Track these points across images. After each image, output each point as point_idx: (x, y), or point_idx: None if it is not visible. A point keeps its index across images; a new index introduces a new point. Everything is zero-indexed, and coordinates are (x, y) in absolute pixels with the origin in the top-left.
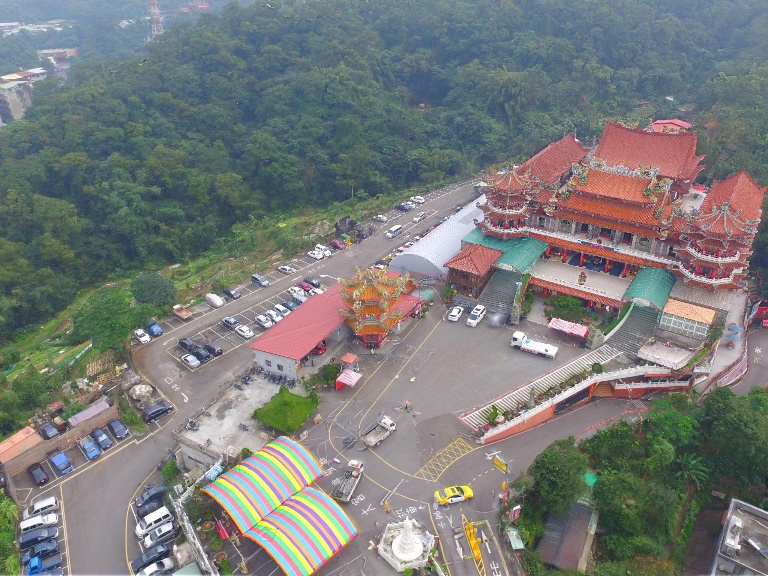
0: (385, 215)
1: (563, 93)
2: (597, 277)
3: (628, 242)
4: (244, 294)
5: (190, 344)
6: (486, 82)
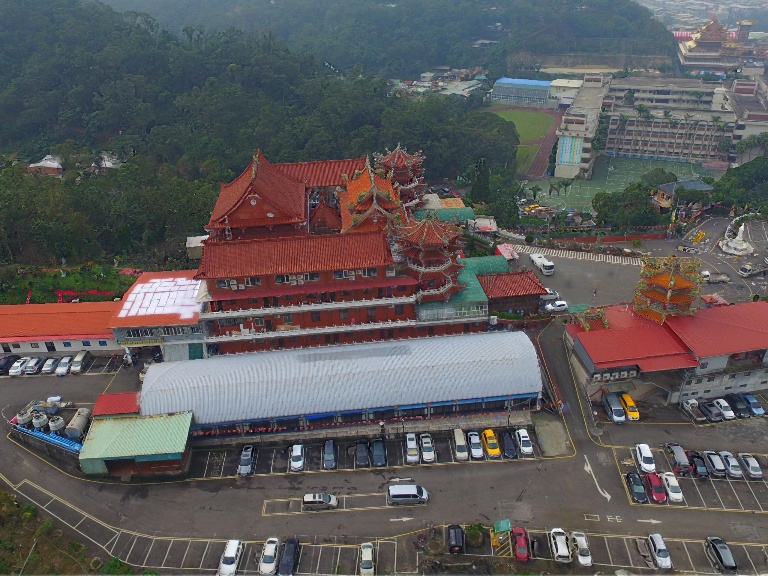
0: (339, 571)
1: None
2: None
3: None
4: (762, 551)
5: None
6: None
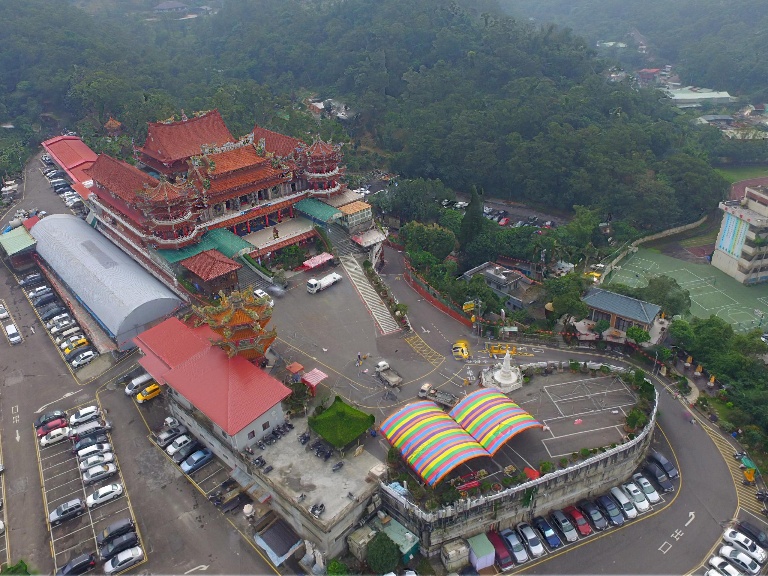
0: None
1: None
2: (271, 231)
3: (261, 199)
4: None
5: (88, 558)
6: None
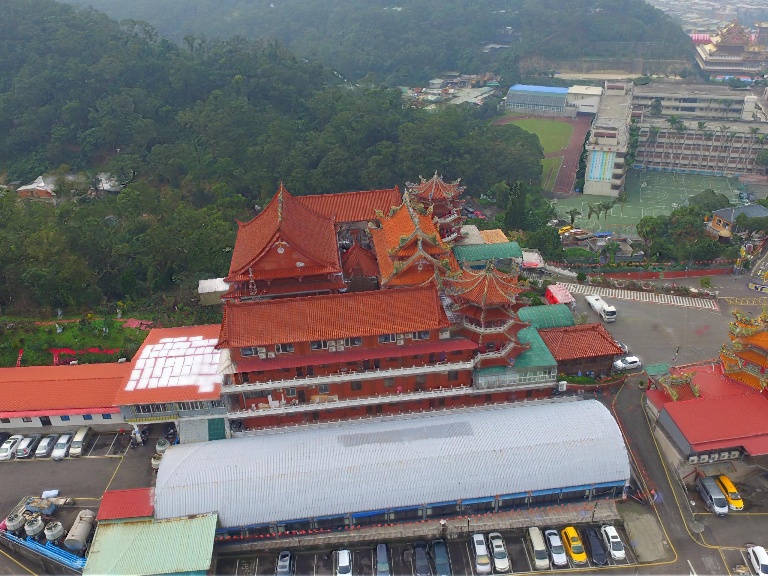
0: None
1: None
2: None
3: None
4: None
5: None
6: None
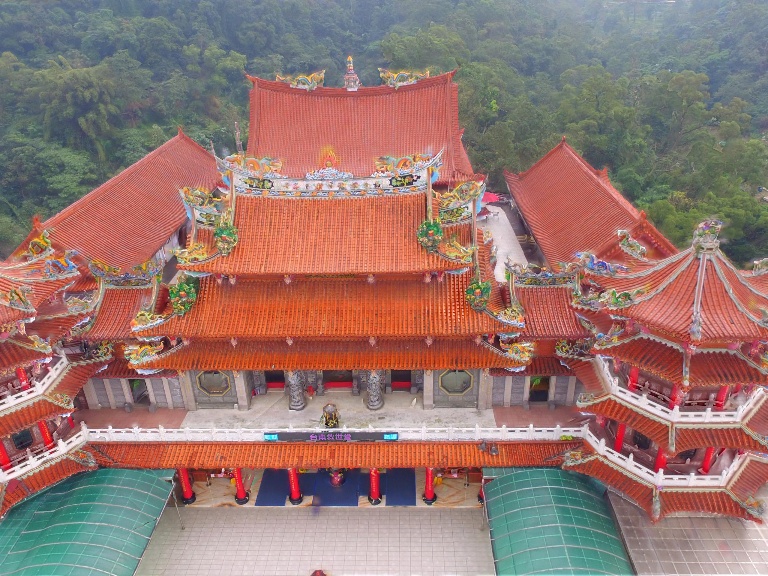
0: None
1: (180, 96)
2: (357, 535)
3: (405, 385)
4: None
5: None
6: (34, 87)
